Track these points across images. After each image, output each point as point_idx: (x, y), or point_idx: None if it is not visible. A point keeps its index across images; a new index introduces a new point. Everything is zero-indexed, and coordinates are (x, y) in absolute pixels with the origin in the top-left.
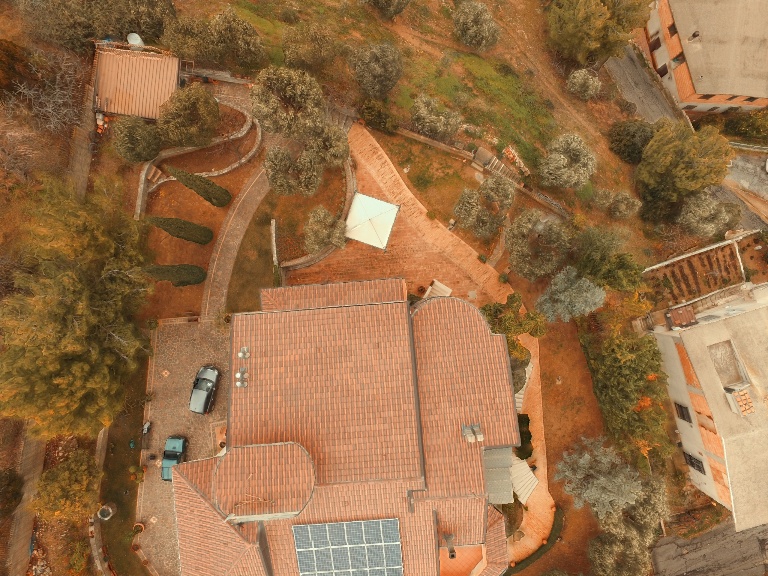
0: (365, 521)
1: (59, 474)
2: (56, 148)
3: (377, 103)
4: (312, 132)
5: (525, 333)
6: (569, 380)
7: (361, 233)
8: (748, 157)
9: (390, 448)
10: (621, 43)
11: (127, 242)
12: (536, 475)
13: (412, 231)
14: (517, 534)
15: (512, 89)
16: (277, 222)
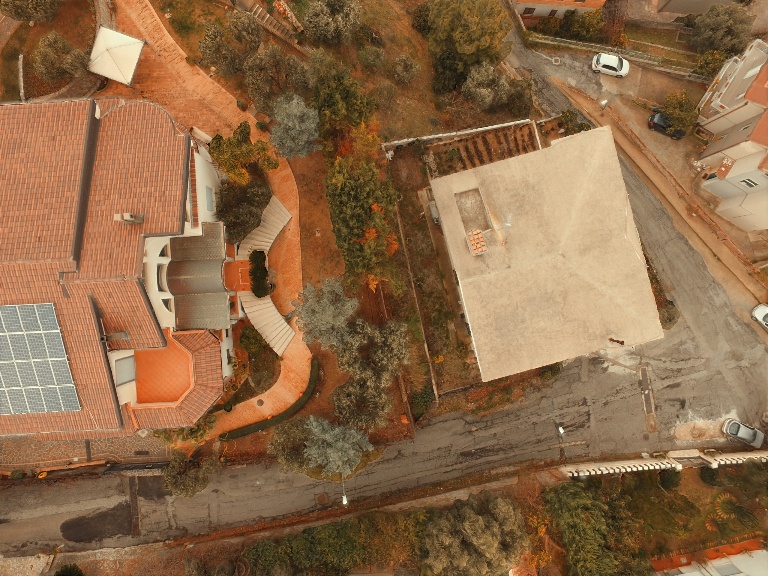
0: (19, 305)
1: None
2: None
3: None
4: None
5: (285, 184)
6: (329, 232)
7: (104, 67)
8: (576, 55)
9: (45, 231)
10: None
11: None
12: (293, 327)
13: (172, 77)
14: (264, 380)
15: None
16: (26, 58)
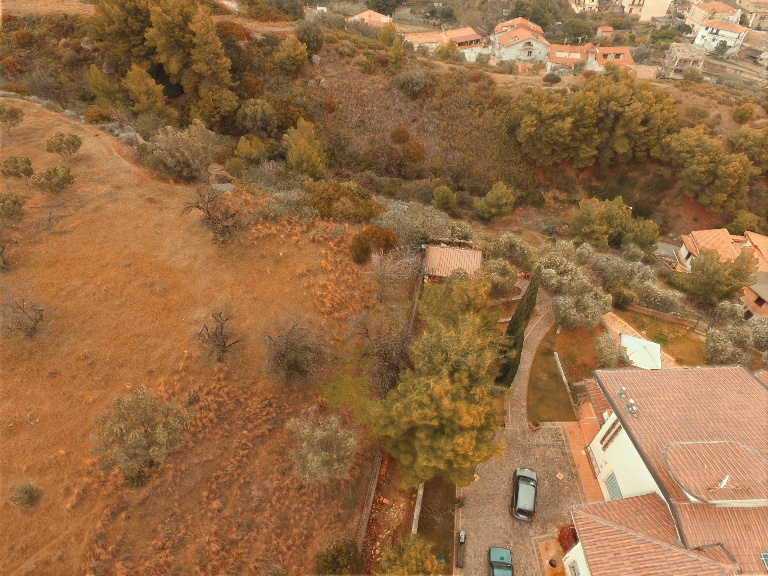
0: None
1: (406, 549)
2: (400, 289)
3: None
4: (585, 289)
5: None
6: None
7: (637, 360)
8: None
9: None
10: (739, 294)
11: (491, 321)
12: None
13: None
14: None
15: None
16: (558, 354)
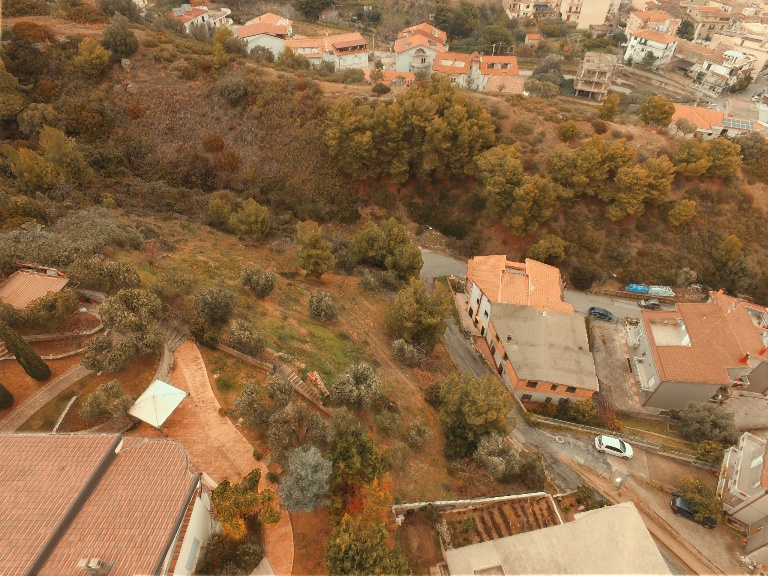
0: None
1: None
2: None
3: (201, 319)
4: (137, 328)
5: (281, 543)
6: None
7: (143, 411)
8: (578, 436)
9: None
10: (439, 331)
11: None
12: None
13: (201, 425)
14: None
15: (343, 347)
16: (78, 399)
